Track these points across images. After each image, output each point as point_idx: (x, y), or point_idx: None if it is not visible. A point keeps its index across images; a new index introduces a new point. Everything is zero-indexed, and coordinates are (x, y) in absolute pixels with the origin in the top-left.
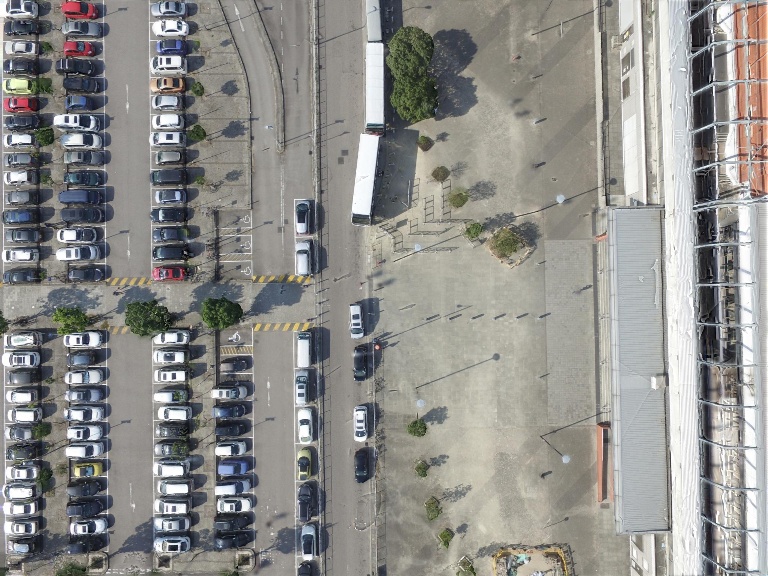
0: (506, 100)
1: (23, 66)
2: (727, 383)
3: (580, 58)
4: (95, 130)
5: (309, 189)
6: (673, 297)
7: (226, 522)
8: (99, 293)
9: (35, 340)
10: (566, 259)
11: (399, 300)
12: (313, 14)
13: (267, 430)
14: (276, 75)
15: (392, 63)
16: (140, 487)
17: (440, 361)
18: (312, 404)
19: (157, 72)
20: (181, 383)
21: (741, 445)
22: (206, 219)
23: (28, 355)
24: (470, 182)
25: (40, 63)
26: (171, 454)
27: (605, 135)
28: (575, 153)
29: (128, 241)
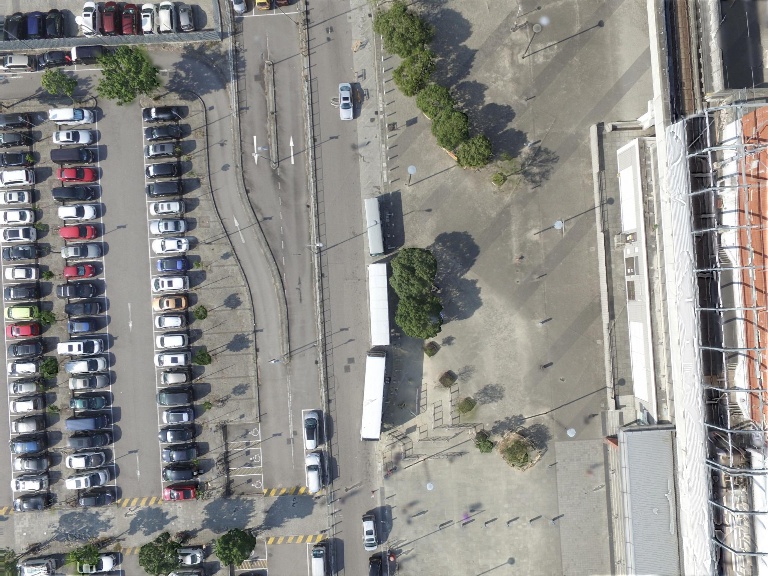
0: (511, 301)
1: (24, 293)
2: None
3: (583, 256)
4: (99, 352)
5: (316, 399)
6: None
7: None
8: (110, 515)
9: (48, 570)
10: (577, 460)
11: (411, 507)
12: (313, 223)
13: None
14: (278, 286)
15: (396, 287)
16: None
17: (455, 567)
18: None
19: (159, 291)
20: None
21: None
22: (214, 434)
23: None
24: (478, 385)
25: (41, 286)
26: None
27: (612, 335)
28: (582, 352)
29: (137, 461)
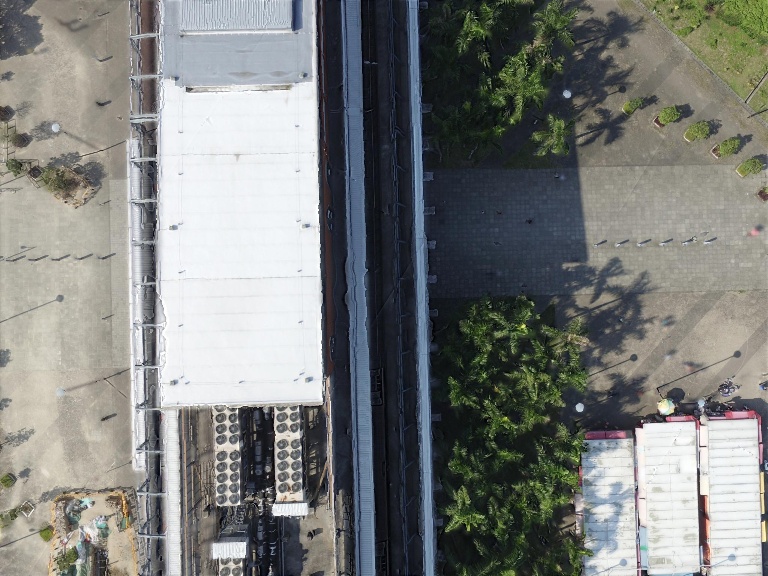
0: (72, 38)
1: None
2: None
3: None
4: None
5: None
6: None
7: None
8: None
9: None
10: None
11: None
12: None
13: None
14: None
15: None
16: None
17: (3, 303)
18: None
19: None
20: None
21: None
22: None
23: None
24: (35, 122)
25: None
26: None
27: None
28: None
29: None
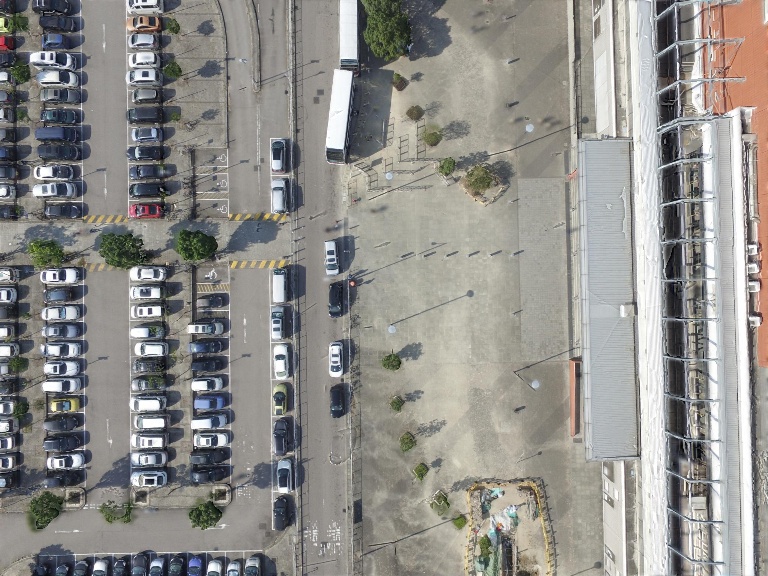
0: (480, 40)
1: None
2: (693, 307)
3: None
4: (72, 68)
5: (285, 128)
6: (640, 223)
7: (202, 456)
8: (76, 230)
9: (12, 276)
10: (539, 197)
11: (374, 238)
12: None
13: (243, 366)
14: (252, 15)
15: None
16: (117, 423)
17: (415, 298)
18: (288, 341)
19: (133, 11)
20: (158, 320)
21: (705, 365)
22: (182, 158)
23: (5, 290)
24: (444, 121)
25: (17, 2)
26: (148, 390)
27: (577, 74)
28: (548, 93)
29: (105, 179)
